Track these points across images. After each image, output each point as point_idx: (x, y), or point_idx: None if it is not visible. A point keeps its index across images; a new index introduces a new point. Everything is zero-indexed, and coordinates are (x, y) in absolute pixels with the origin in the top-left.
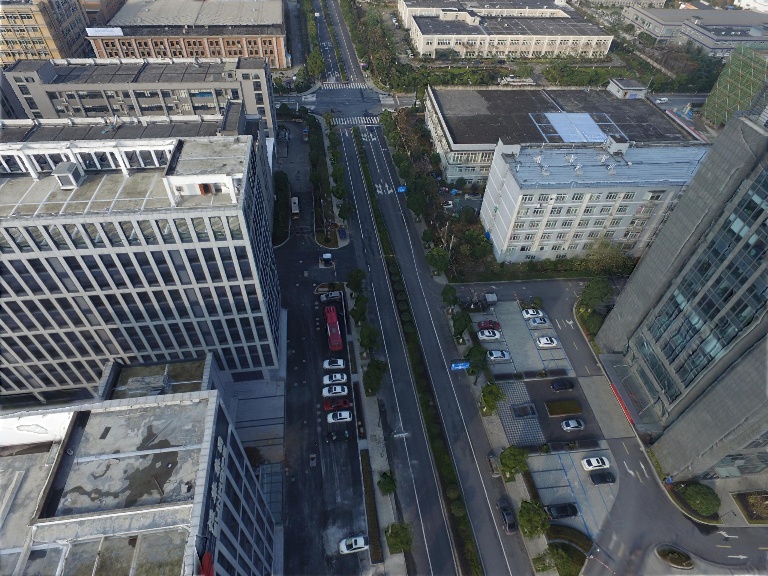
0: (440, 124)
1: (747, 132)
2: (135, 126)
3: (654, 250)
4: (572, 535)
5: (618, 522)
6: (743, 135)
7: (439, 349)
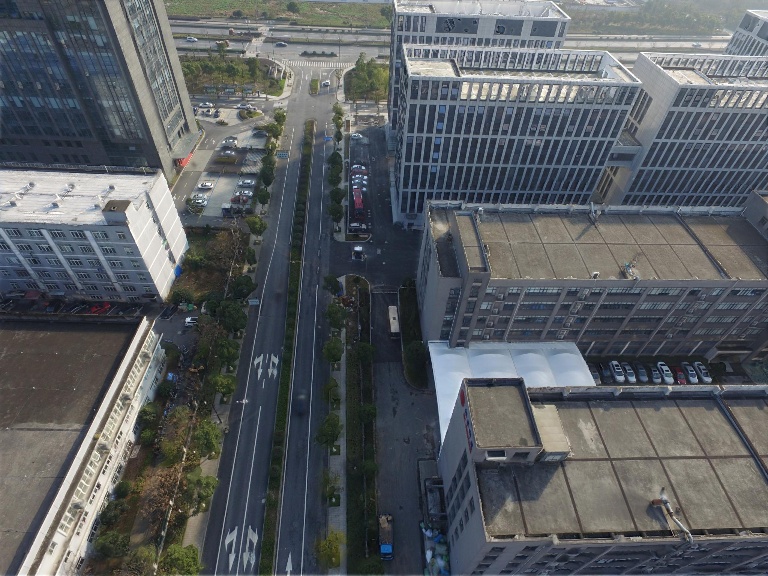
0: (116, 399)
1: (74, 4)
2: (606, 277)
3: (140, 91)
4: (262, 128)
5: (237, 131)
6: (75, 7)
7: (285, 193)
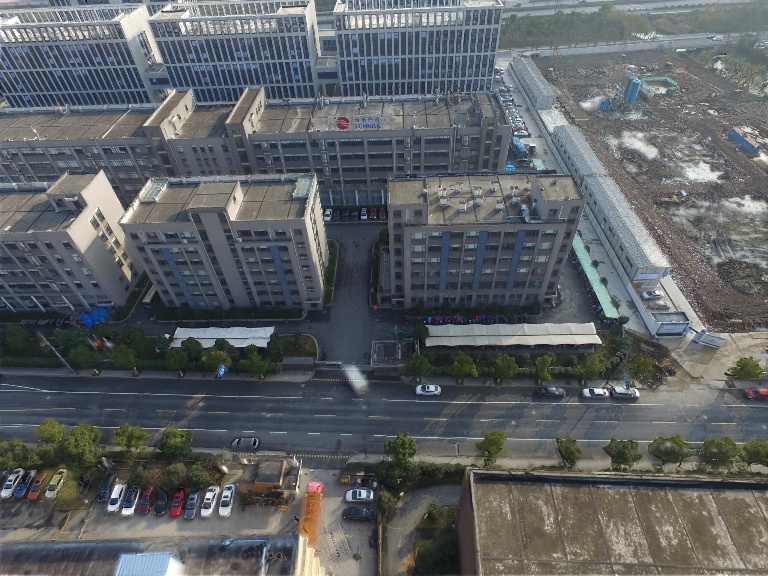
0: None
1: None
2: None
3: None
4: None
5: None
6: None
7: None
